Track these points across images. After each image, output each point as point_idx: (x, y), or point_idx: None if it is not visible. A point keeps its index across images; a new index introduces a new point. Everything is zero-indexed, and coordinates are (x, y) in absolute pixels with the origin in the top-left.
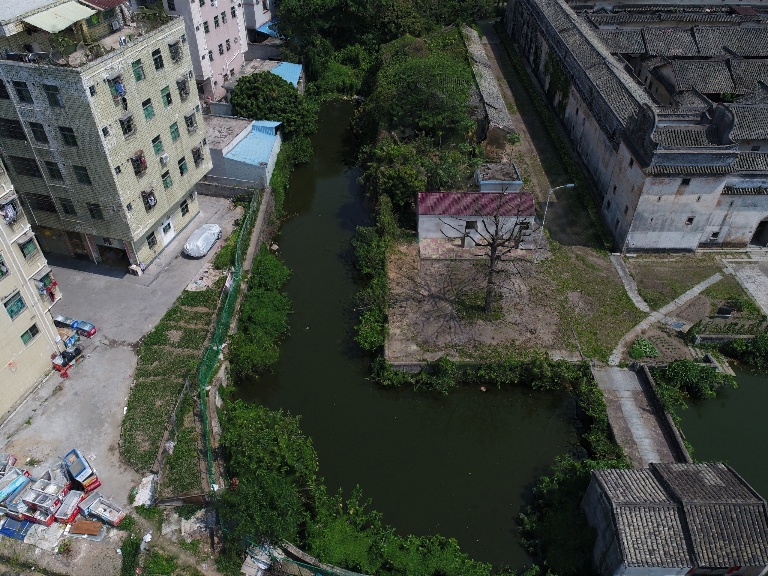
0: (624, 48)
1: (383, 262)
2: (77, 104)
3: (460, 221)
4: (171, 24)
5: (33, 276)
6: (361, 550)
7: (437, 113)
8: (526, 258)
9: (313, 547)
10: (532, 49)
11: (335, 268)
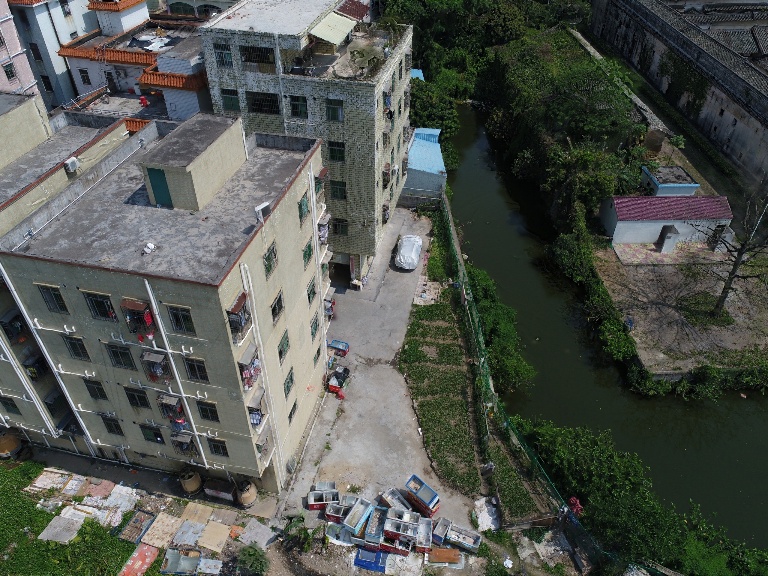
0: (737, 48)
1: (592, 269)
2: (360, 118)
3: (657, 226)
4: (408, 33)
5: (324, 296)
6: (723, 566)
7: (593, 117)
8: (727, 261)
9: (685, 566)
10: (636, 50)
11: (534, 276)
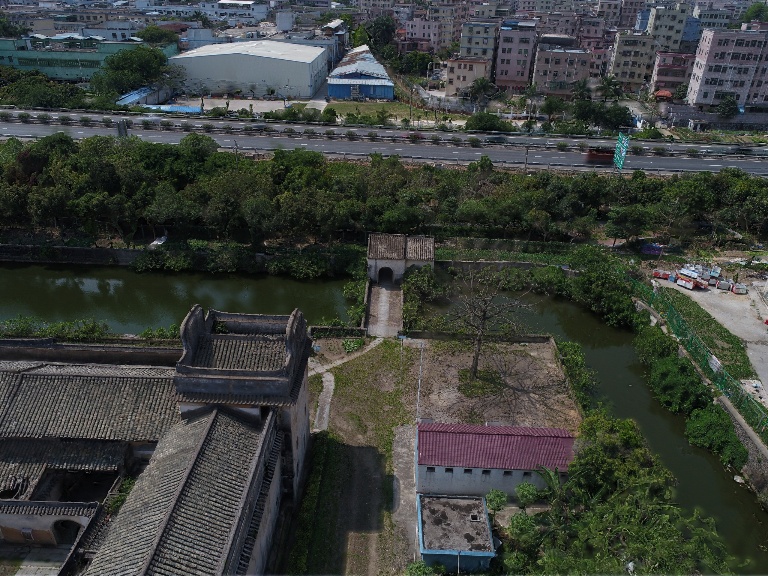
0: None
1: None
2: None
3: None
4: None
5: None
6: None
7: None
8: None
9: None
10: None
11: None
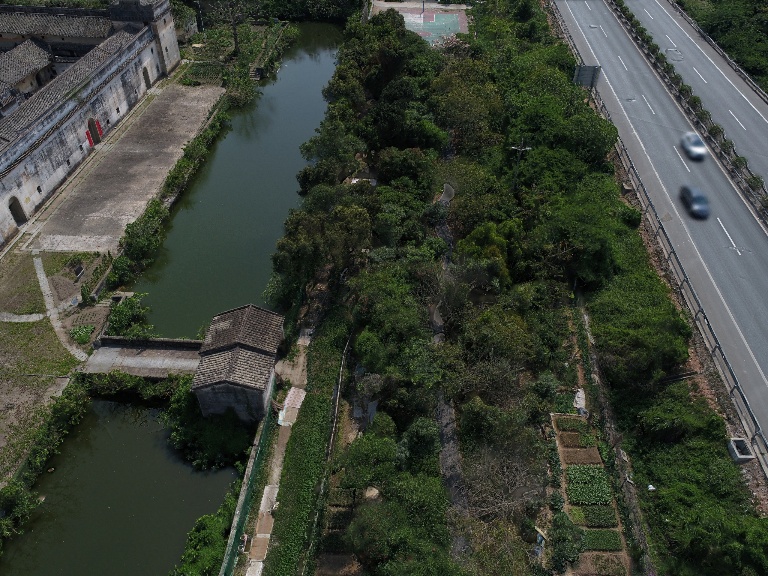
0: None
1: None
2: None
3: None
4: None
5: None
6: None
7: None
8: None
9: None
10: None
11: None
